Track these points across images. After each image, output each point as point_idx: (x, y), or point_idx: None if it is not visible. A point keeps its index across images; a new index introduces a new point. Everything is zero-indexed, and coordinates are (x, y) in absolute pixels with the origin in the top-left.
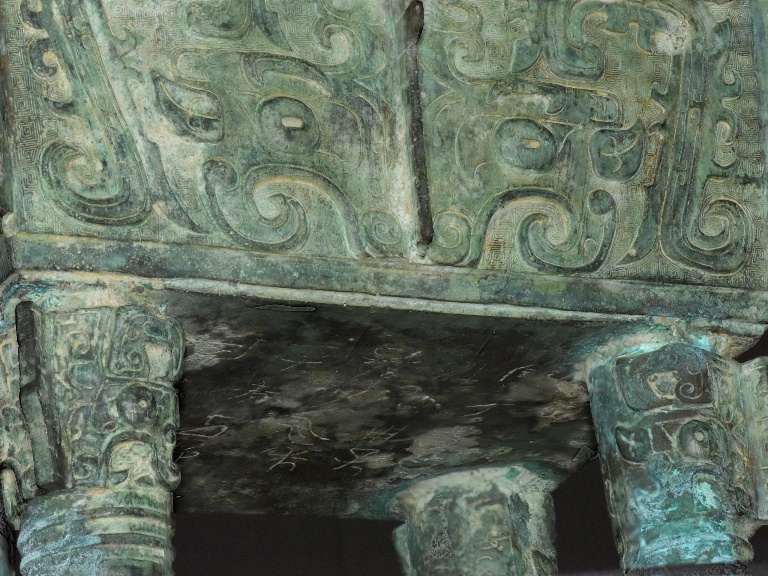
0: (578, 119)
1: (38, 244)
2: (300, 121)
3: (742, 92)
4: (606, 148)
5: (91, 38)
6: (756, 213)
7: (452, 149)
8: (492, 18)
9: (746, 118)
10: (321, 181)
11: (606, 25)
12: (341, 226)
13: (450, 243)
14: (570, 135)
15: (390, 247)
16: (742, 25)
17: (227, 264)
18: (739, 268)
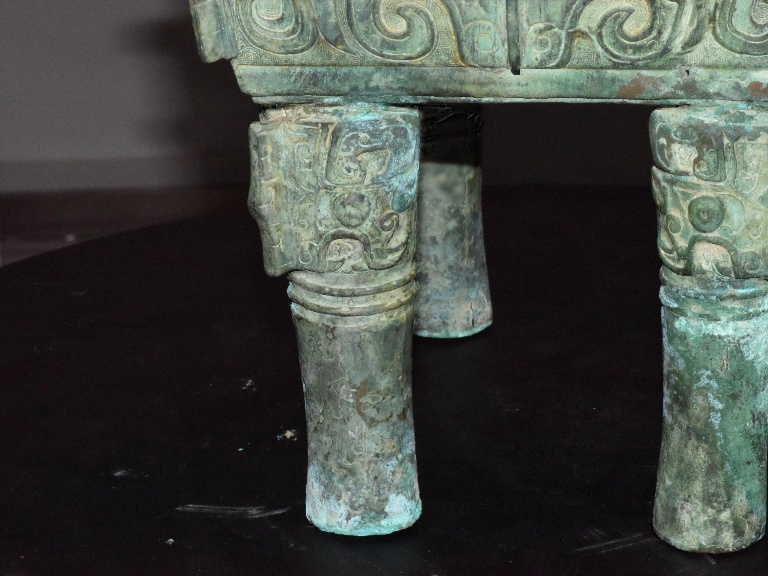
0: None
1: None
2: None
3: None
4: None
5: None
6: None
7: None
8: None
9: None
10: None
11: None
12: None
13: None
14: None
15: None
16: None
17: None
18: None
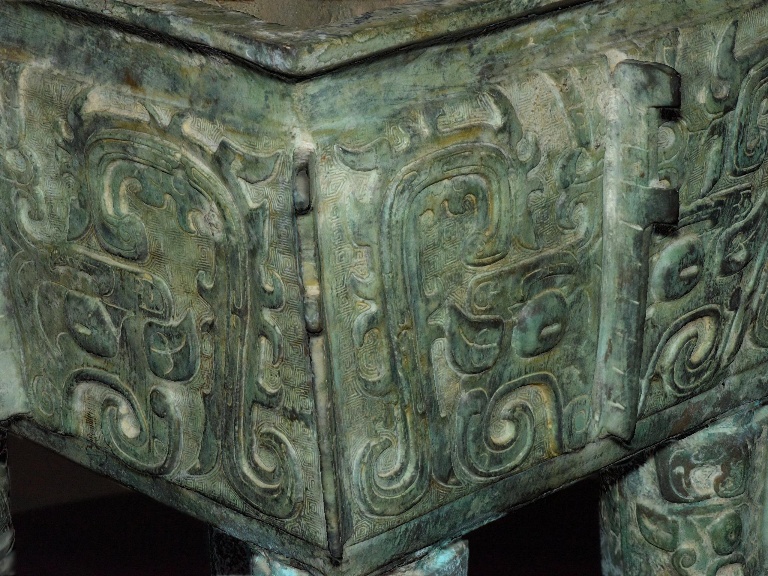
0: (129, 305)
1: None
2: None
3: (285, 303)
4: (157, 344)
5: None
6: (306, 458)
7: (34, 313)
8: (48, 168)
9: (290, 337)
10: None
11: (141, 196)
12: None
13: (47, 410)
14: (124, 321)
15: None
16: (282, 213)
17: None
18: (294, 515)
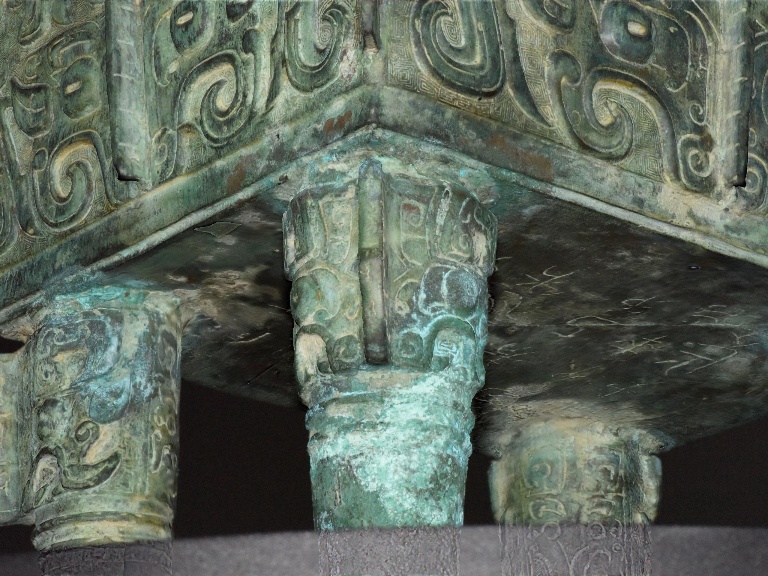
0: None
1: None
2: None
3: None
4: None
5: None
6: None
7: None
8: None
9: None
10: None
11: None
12: None
13: None
14: None
15: None
16: None
17: None
18: None
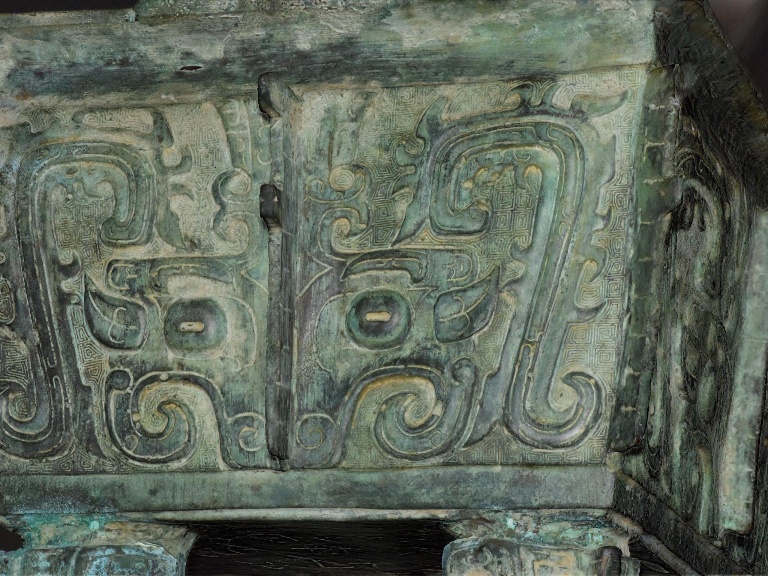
0: None
1: (622, 485)
2: (716, 392)
3: None
4: None
5: (670, 272)
6: None
7: None
8: None
9: None
10: (711, 455)
11: None
12: (702, 499)
13: None
14: None
15: (716, 528)
16: None
17: (666, 525)
18: None
